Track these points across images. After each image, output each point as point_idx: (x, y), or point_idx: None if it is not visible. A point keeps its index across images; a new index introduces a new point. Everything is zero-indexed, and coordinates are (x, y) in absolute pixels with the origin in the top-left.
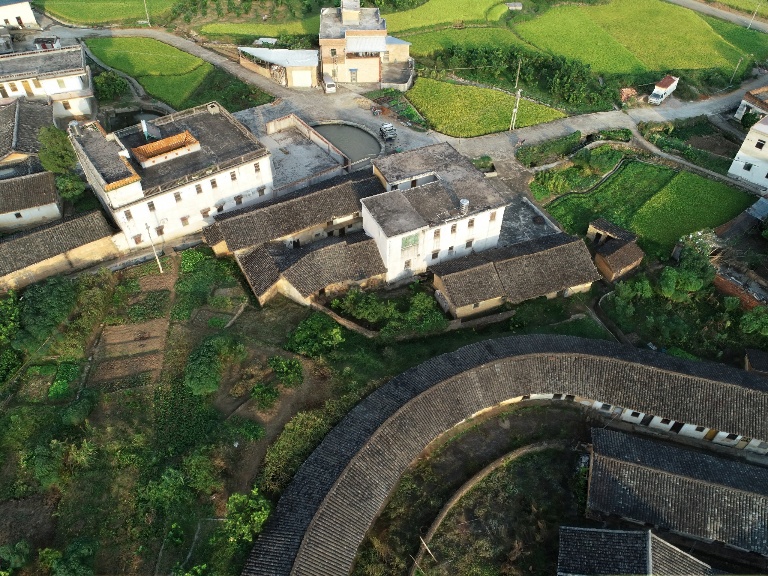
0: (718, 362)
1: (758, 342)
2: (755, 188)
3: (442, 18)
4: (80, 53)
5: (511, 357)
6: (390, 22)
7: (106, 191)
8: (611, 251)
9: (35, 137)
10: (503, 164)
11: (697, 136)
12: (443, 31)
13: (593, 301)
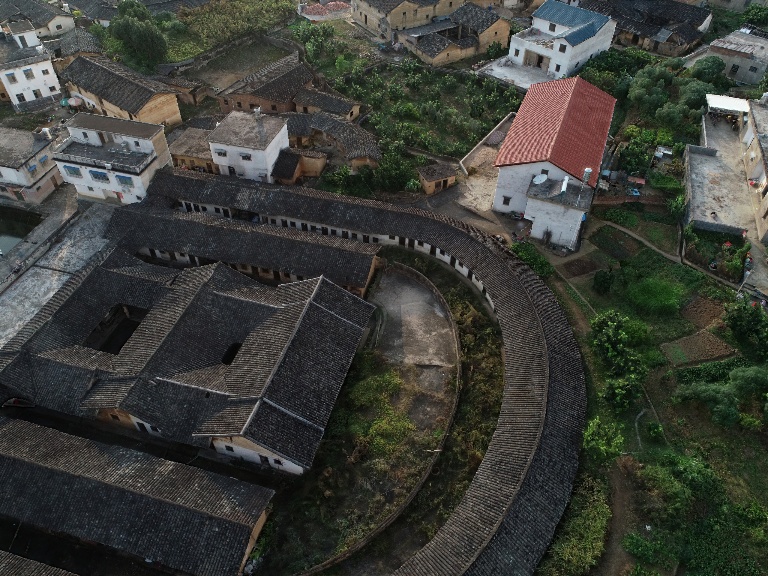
0: None
1: None
2: None
3: None
4: None
5: None
6: None
7: None
8: None
9: None
10: None
11: None
12: None
13: None
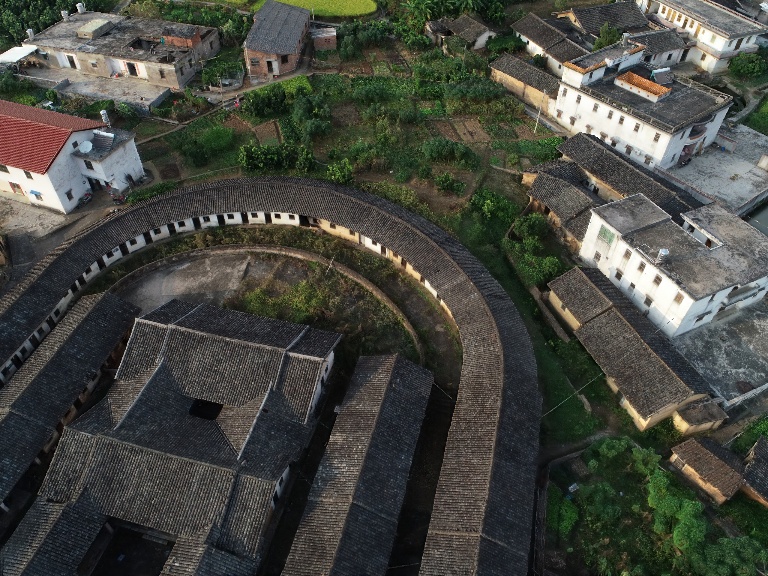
0: (566, 559)
1: None
2: None
3: None
4: None
5: (486, 303)
6: None
7: (563, 64)
8: (710, 448)
9: None
10: None
11: None
12: None
13: None
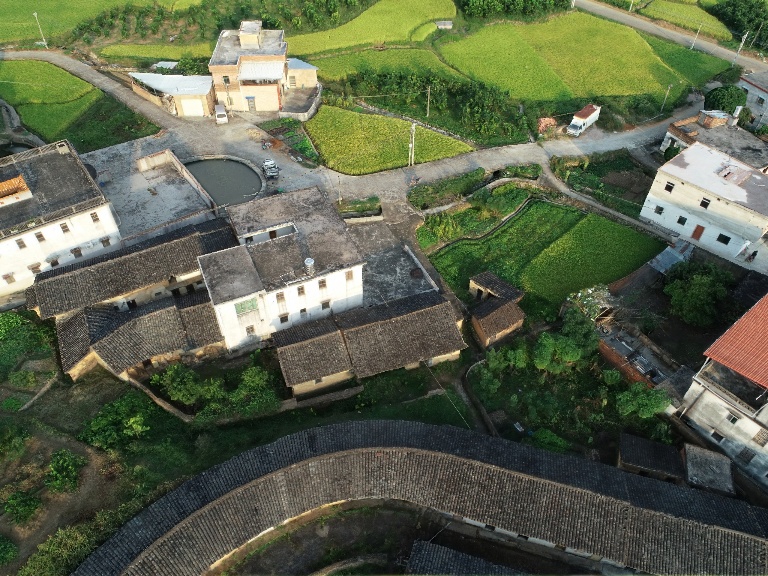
0: (590, 448)
1: (640, 423)
2: (666, 234)
3: (362, 39)
4: None
5: (330, 453)
6: (305, 43)
7: None
8: (487, 312)
9: None
10: (392, 206)
11: (615, 172)
12: (361, 53)
13: (463, 370)
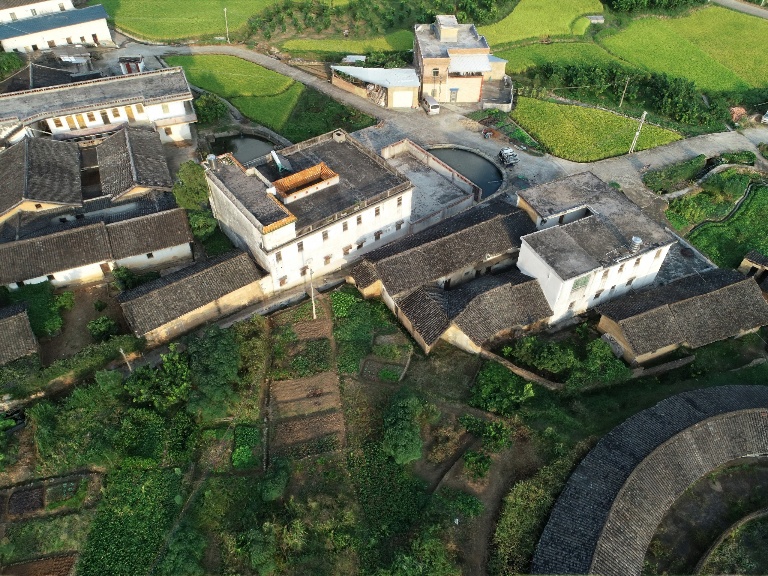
0: None
1: None
2: None
3: (528, 33)
4: (181, 75)
5: (723, 414)
6: None
7: (264, 233)
8: None
9: (152, 168)
10: (633, 191)
11: None
12: (531, 46)
13: (763, 342)
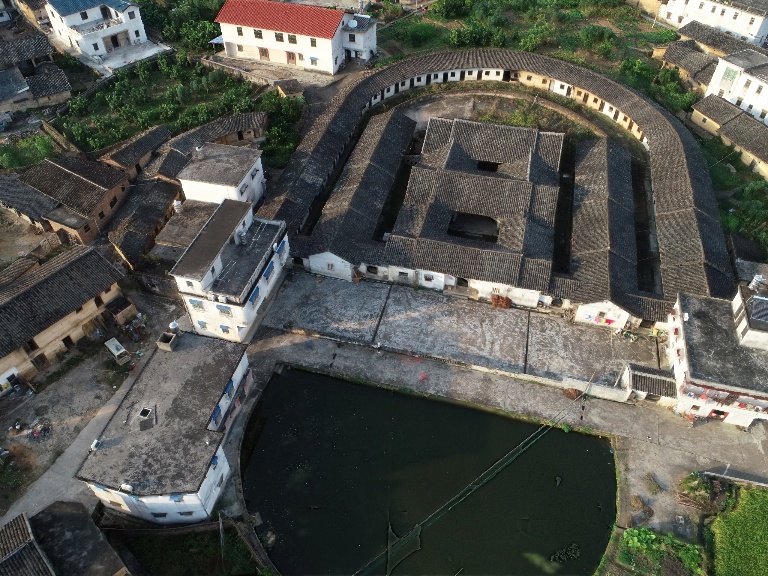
0: None
1: None
2: None
3: None
4: None
5: None
6: None
7: None
8: None
9: None
10: None
11: None
12: None
13: None
